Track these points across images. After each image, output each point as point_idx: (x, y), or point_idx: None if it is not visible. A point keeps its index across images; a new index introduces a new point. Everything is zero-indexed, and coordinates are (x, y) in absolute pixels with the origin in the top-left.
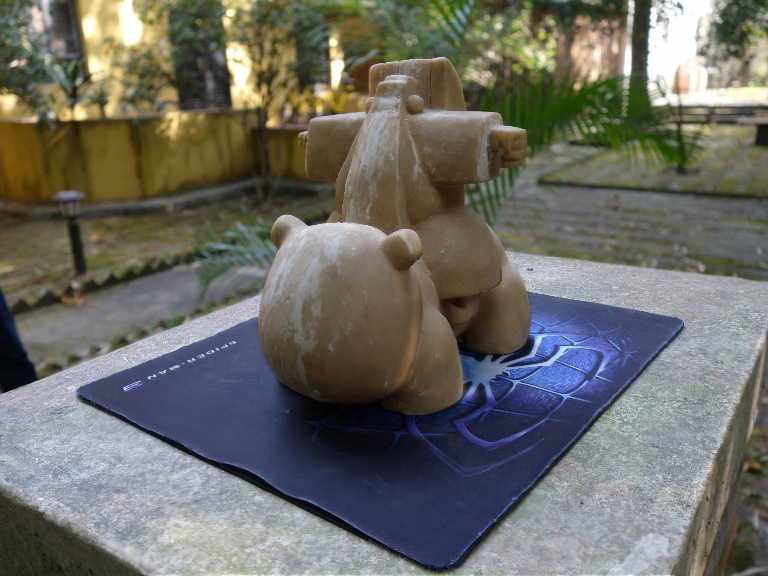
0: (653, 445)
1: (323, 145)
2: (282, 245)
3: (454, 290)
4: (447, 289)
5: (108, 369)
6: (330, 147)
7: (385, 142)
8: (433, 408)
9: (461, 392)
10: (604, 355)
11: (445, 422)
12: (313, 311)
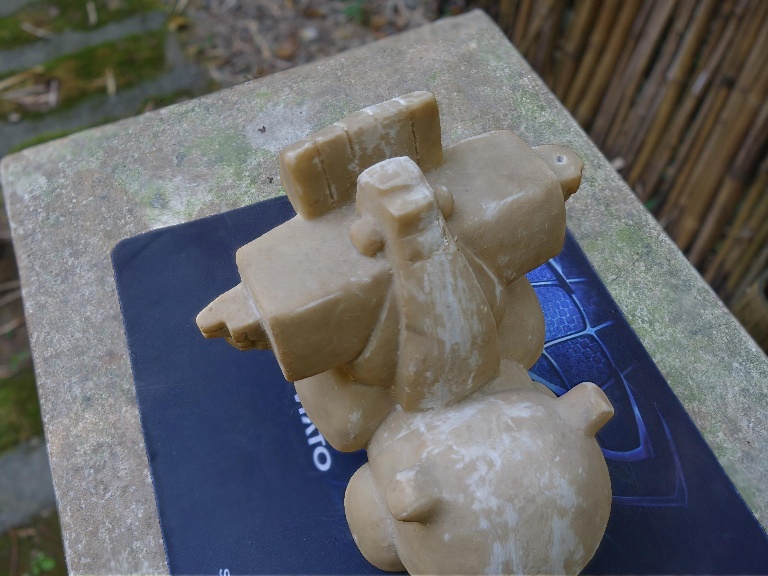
0: (693, 333)
1: (322, 340)
2: (453, 526)
3: None
4: None
5: None
6: (338, 336)
7: (468, 298)
8: None
9: None
10: None
11: None
12: (577, 557)
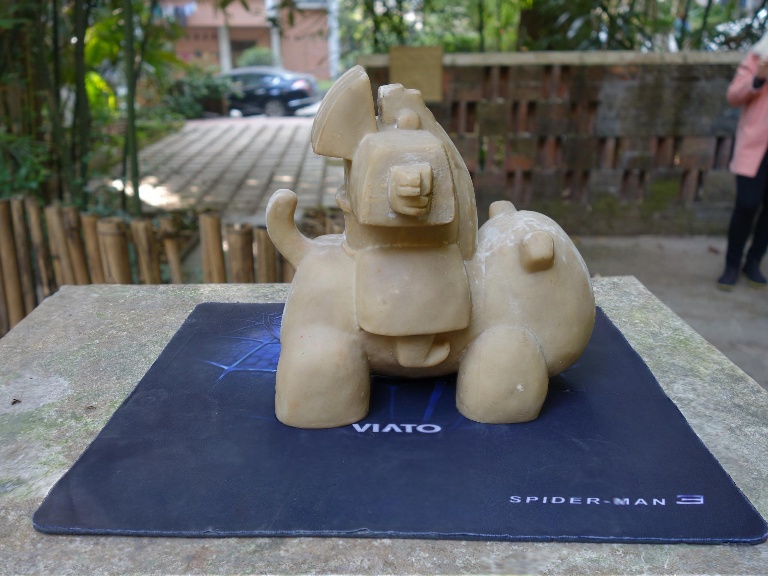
0: None
1: None
2: (561, 249)
3: None
4: None
5: (712, 572)
6: None
7: None
8: None
9: None
10: None
11: None
12: None
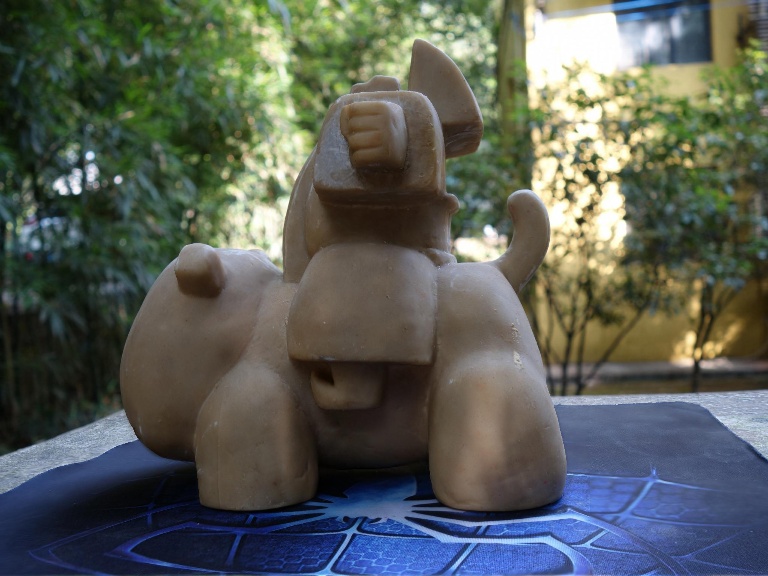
0: None
1: None
2: None
3: (290, 347)
4: (288, 344)
5: None
6: None
7: None
8: (206, 499)
9: (261, 501)
10: (555, 575)
11: (186, 518)
12: None
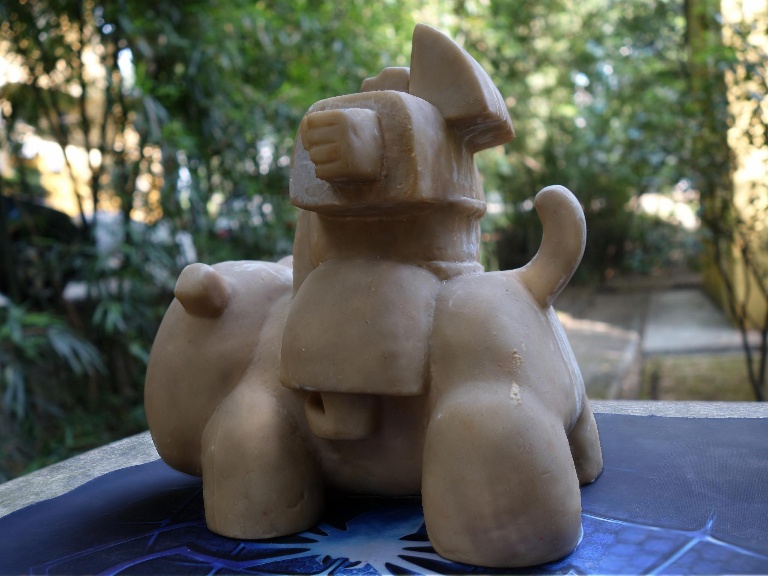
0: None
1: None
2: None
3: None
4: None
5: None
6: None
7: None
8: None
9: (252, 530)
10: None
11: (183, 541)
12: None
